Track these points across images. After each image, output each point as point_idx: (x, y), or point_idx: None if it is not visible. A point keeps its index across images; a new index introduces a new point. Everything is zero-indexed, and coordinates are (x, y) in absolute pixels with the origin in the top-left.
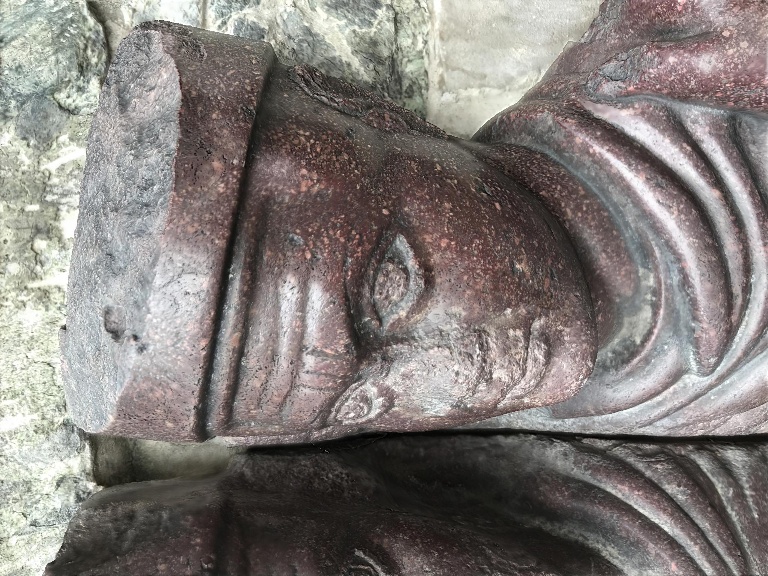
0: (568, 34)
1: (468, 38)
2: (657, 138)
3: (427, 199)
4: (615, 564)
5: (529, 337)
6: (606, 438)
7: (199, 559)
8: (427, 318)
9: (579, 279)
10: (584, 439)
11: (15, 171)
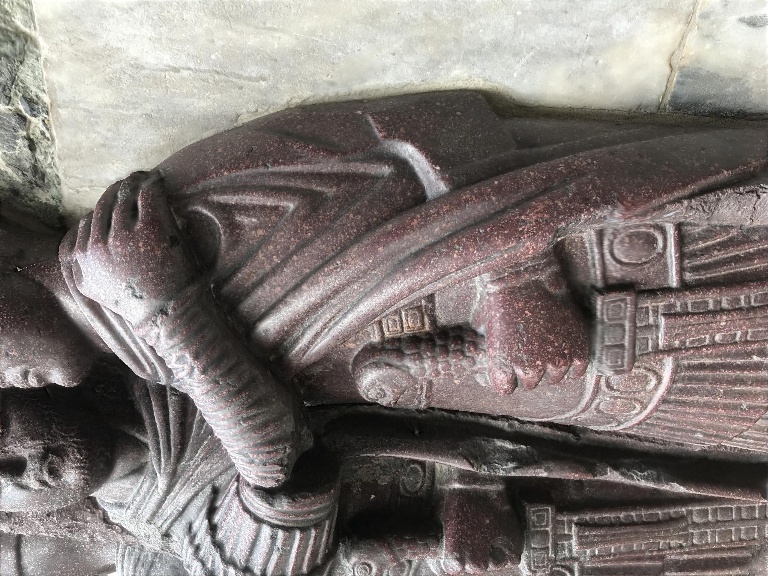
0: (151, 153)
1: (78, 158)
2: None
3: None
4: None
5: None
6: None
7: None
8: None
9: (59, 350)
10: None
11: None
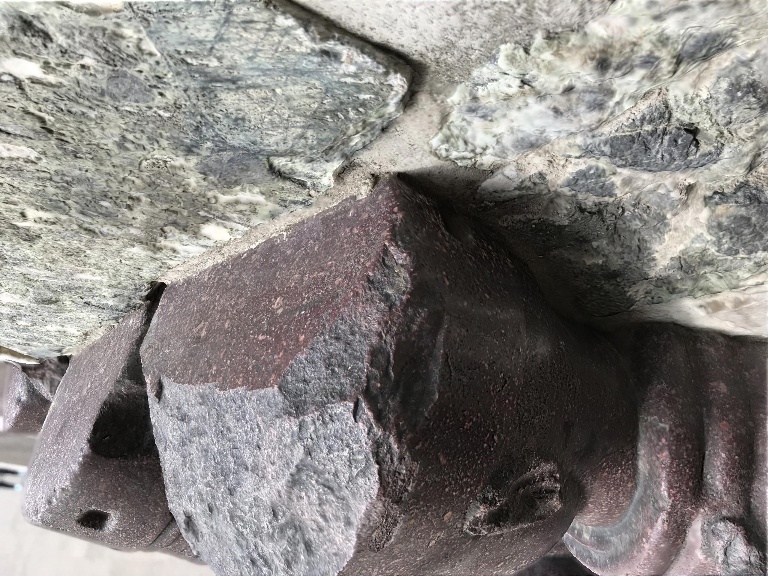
0: None
1: None
2: (685, 570)
3: None
4: None
5: None
6: None
7: None
8: None
9: None
10: None
11: (175, 187)
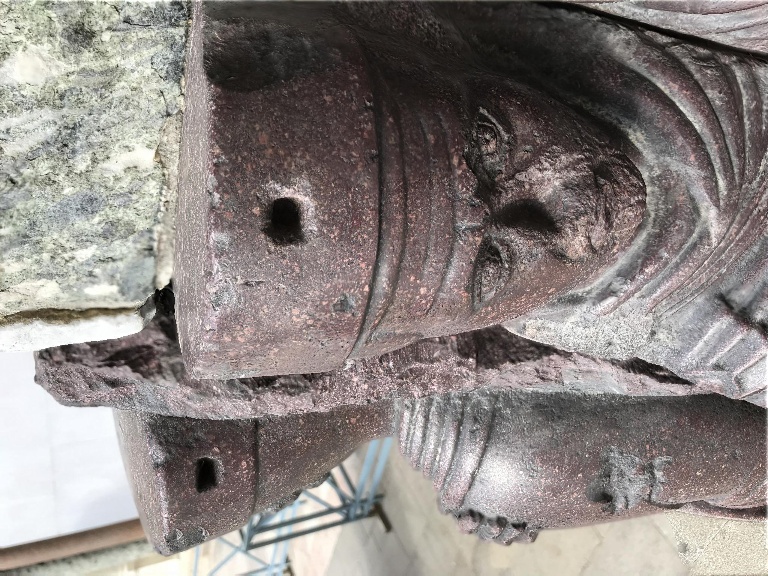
0: None
1: None
2: None
3: None
4: (638, 147)
5: None
6: (667, 34)
7: (361, 96)
8: None
9: None
10: (647, 31)
11: None
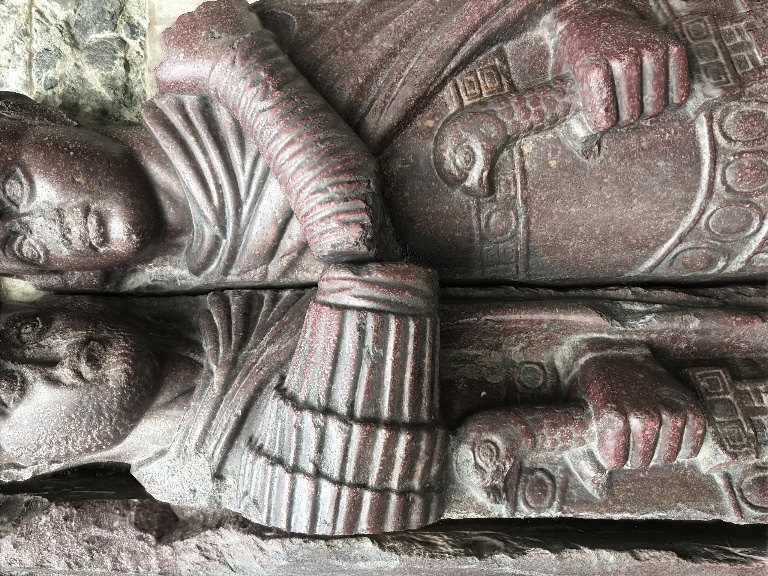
0: None
1: None
2: (171, 114)
3: (32, 152)
4: (204, 349)
5: (85, 212)
6: (233, 289)
7: None
8: (37, 205)
9: (125, 186)
10: None
11: None
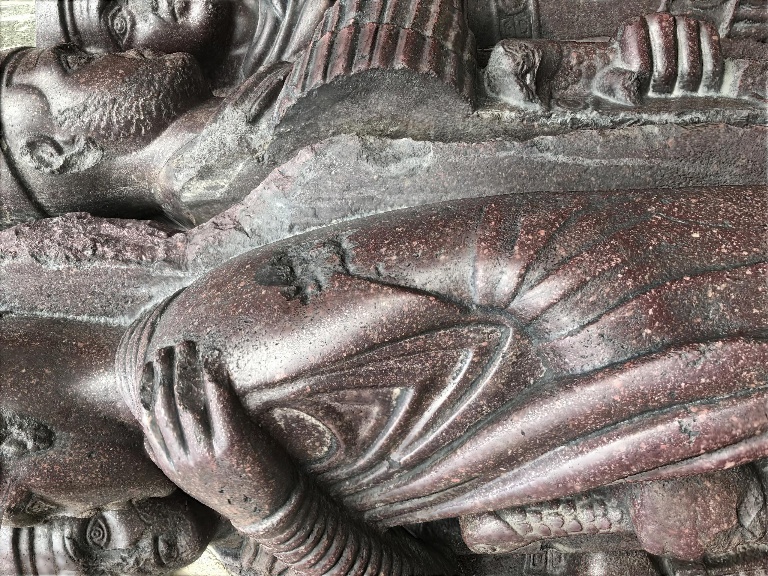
0: None
1: None
2: None
3: None
4: None
5: None
6: None
7: None
8: None
9: None
10: None
11: None
